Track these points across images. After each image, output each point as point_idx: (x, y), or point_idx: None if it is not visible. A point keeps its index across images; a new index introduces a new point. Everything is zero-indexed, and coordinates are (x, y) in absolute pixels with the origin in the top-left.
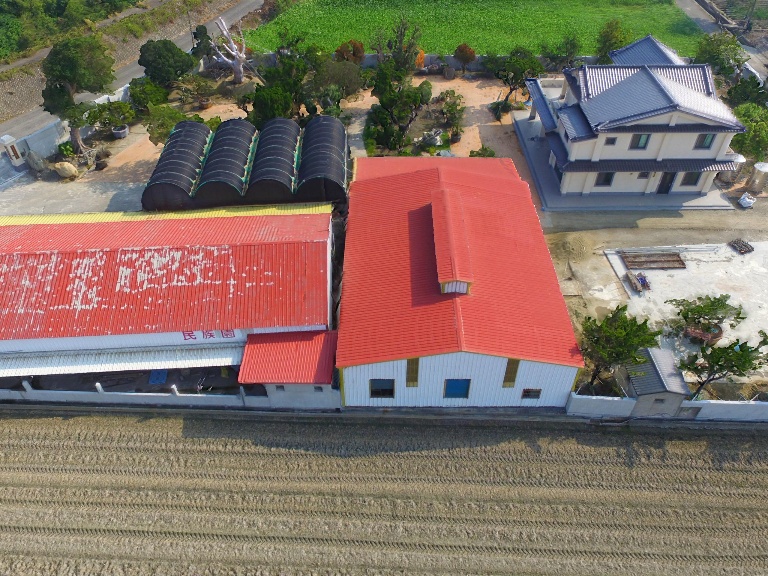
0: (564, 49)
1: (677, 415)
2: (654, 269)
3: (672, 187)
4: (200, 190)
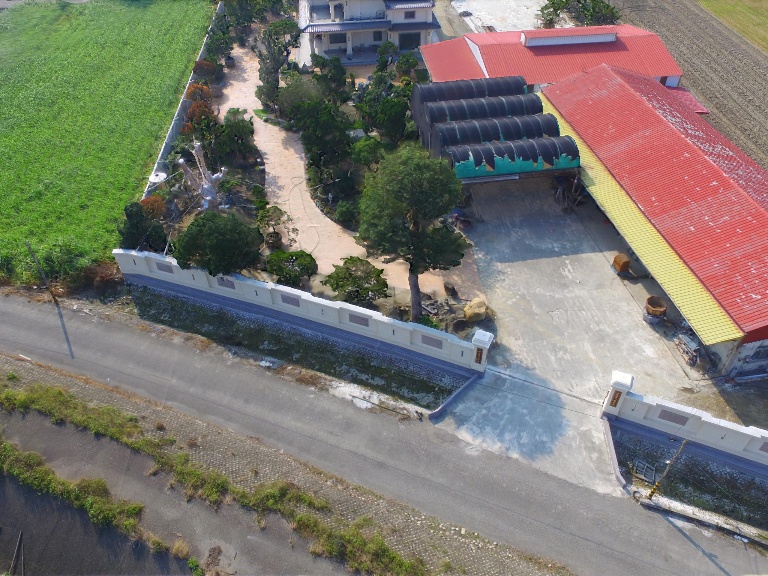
0: None
1: None
2: None
3: None
4: None
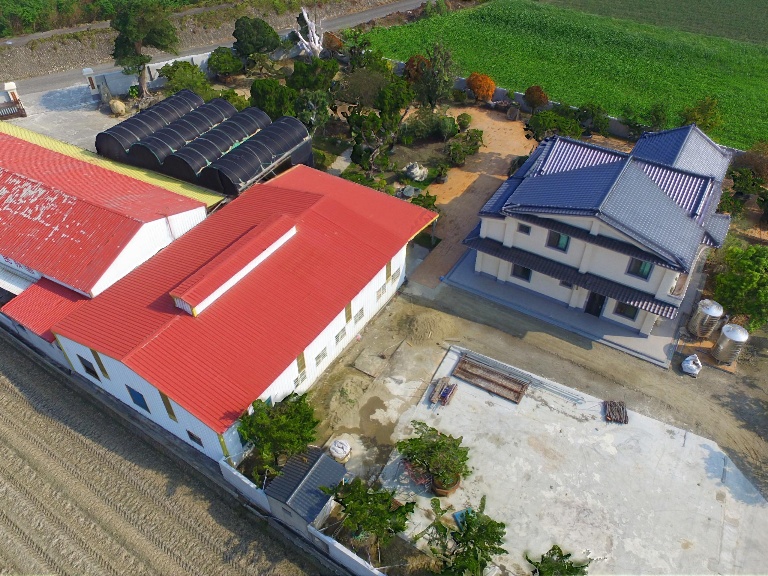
0: (650, 119)
1: (312, 539)
2: (480, 388)
3: (603, 311)
4: (132, 149)
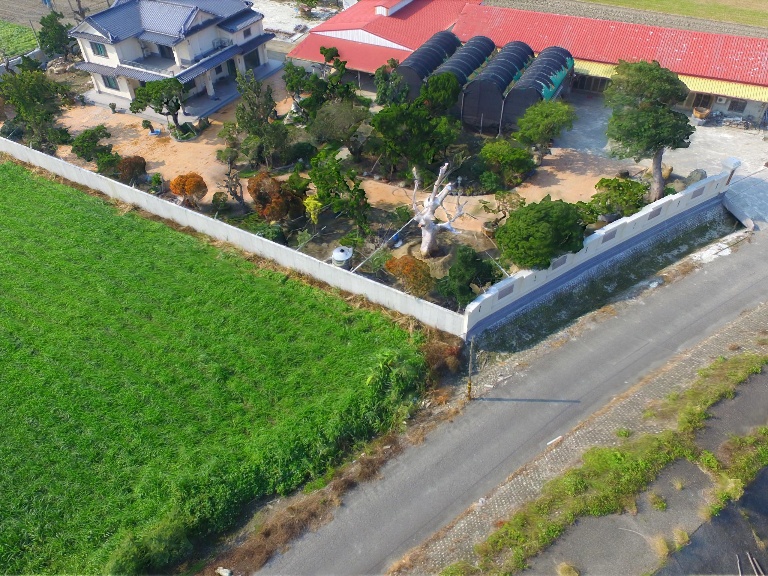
0: None
1: None
2: None
3: None
4: None
